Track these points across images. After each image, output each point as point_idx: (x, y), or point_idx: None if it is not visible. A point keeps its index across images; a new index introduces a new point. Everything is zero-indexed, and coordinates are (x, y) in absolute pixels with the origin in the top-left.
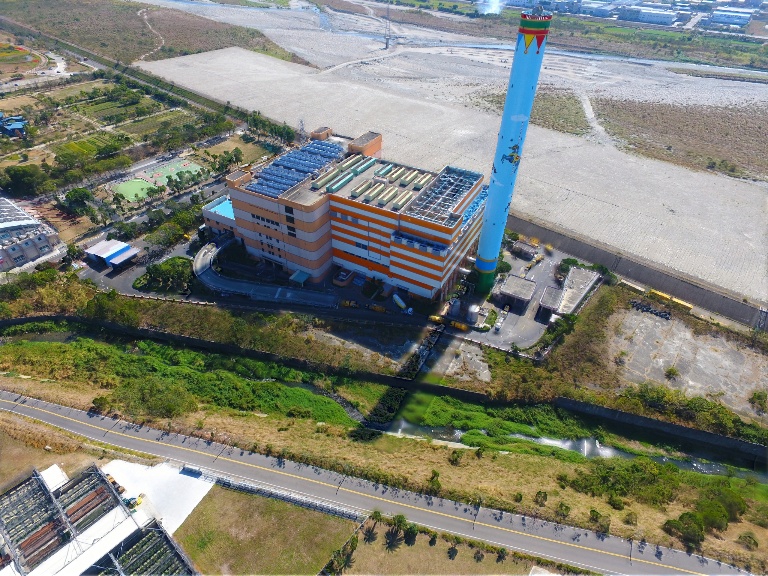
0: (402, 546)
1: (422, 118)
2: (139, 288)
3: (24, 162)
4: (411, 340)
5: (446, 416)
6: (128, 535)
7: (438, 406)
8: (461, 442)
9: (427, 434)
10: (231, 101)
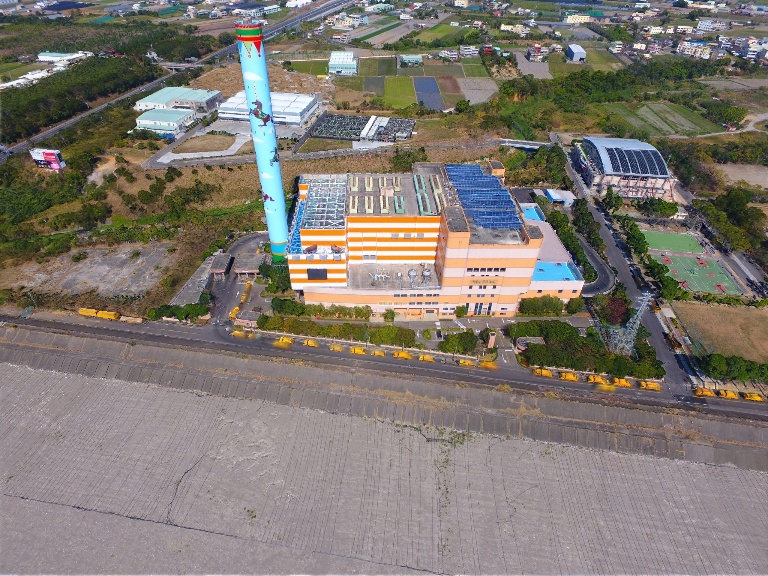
0: None
1: None
2: None
3: None
4: None
5: None
6: None
7: (287, 207)
8: None
9: (288, 199)
10: None
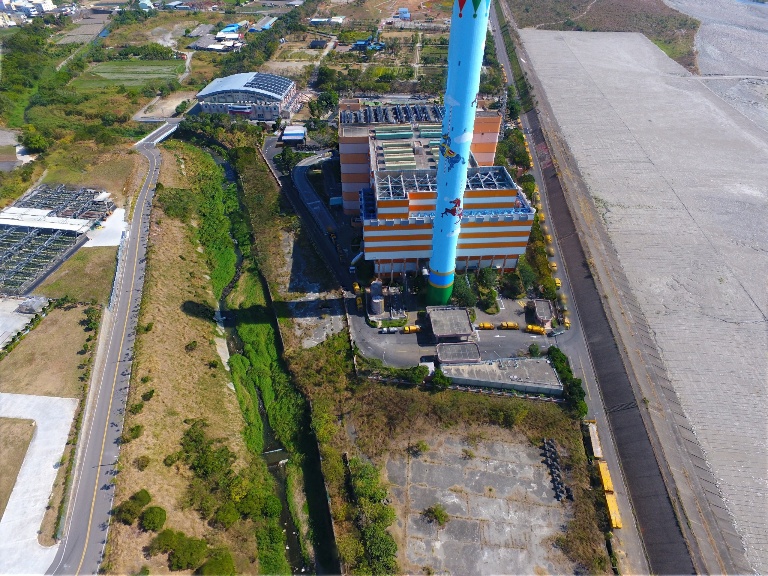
0: (83, 327)
1: (719, 156)
2: (275, 158)
3: (344, 70)
4: (320, 285)
5: (252, 337)
6: (71, 230)
7: (261, 330)
8: (231, 356)
9: (229, 334)
10: (542, 75)
